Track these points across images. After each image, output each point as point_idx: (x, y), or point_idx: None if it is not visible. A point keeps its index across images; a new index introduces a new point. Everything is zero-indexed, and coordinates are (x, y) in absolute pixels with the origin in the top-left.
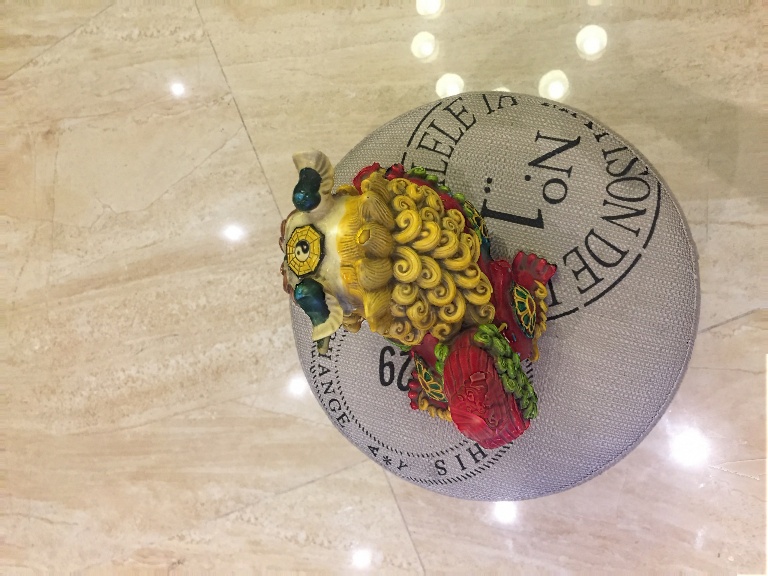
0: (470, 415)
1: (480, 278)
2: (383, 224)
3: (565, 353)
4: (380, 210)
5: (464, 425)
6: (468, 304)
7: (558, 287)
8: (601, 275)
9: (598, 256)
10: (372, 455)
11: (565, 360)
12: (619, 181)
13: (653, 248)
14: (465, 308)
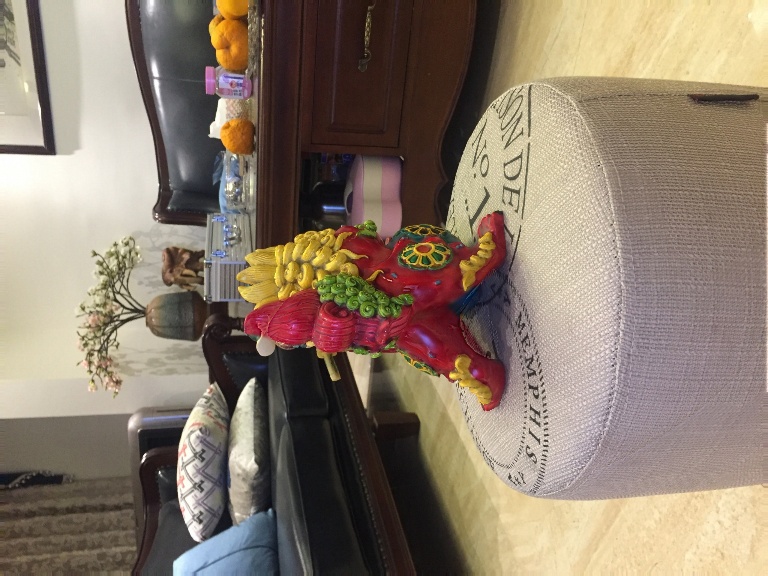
0: (279, 326)
1: (323, 251)
2: (265, 264)
3: (530, 268)
4: (258, 258)
5: (274, 334)
6: (332, 273)
7: (509, 224)
8: (519, 186)
9: (512, 176)
10: (516, 486)
11: (532, 274)
12: (505, 115)
13: (534, 129)
14: (323, 276)
